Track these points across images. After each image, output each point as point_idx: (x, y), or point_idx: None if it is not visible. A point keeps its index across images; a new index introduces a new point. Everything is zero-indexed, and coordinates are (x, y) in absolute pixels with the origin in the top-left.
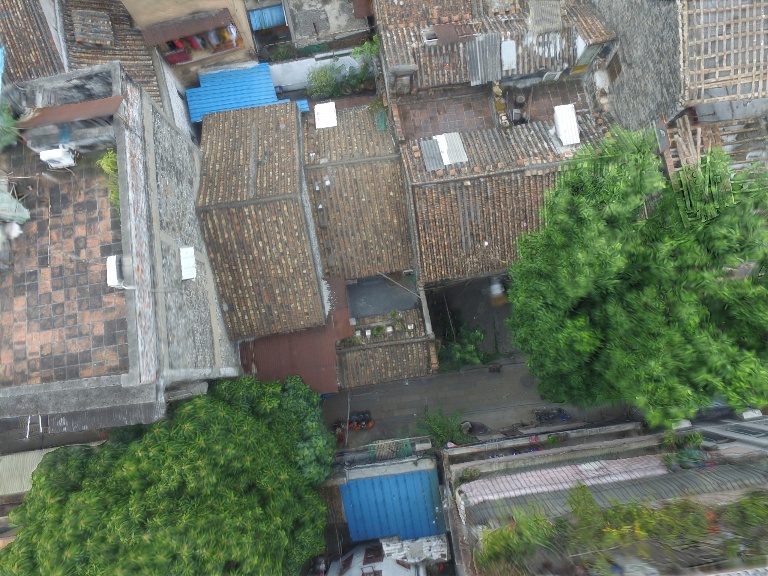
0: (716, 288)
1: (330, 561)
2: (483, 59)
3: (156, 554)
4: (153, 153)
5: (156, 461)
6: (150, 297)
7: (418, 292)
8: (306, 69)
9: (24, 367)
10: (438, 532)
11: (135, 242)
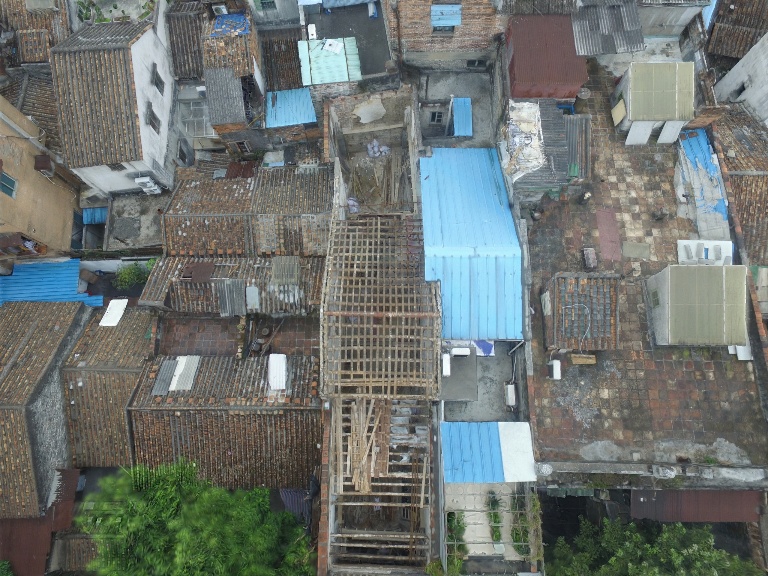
0: None
1: None
2: (230, 298)
3: None
4: None
5: None
6: None
7: None
8: (116, 265)
9: None
10: None
11: None
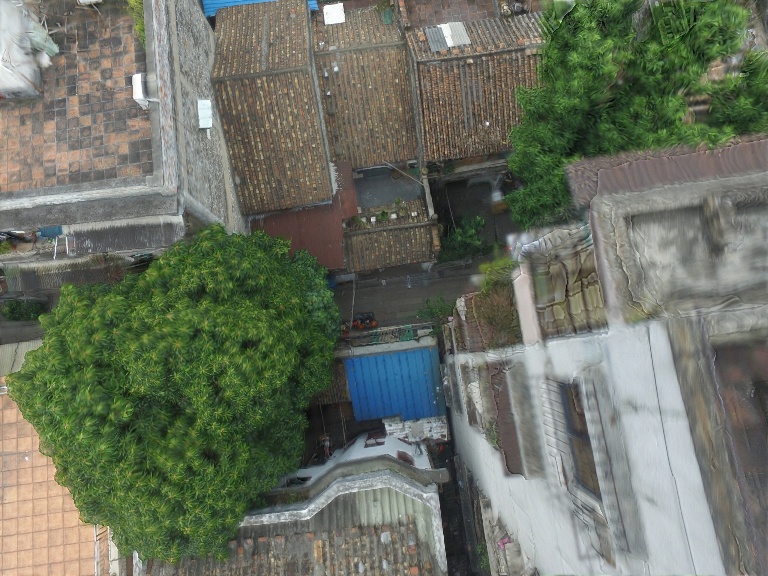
0: (701, 89)
1: (334, 450)
2: None
3: (179, 328)
4: (173, 4)
5: (176, 269)
6: (172, 121)
7: (422, 180)
8: None
9: (54, 182)
10: (438, 413)
11: (158, 65)
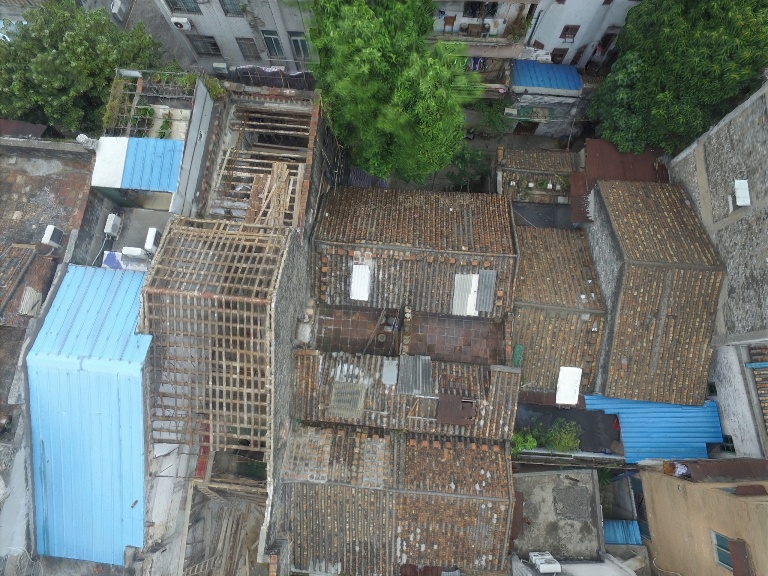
0: None
1: None
2: (416, 375)
3: None
4: None
5: None
6: None
7: None
8: None
9: None
10: None
11: None
